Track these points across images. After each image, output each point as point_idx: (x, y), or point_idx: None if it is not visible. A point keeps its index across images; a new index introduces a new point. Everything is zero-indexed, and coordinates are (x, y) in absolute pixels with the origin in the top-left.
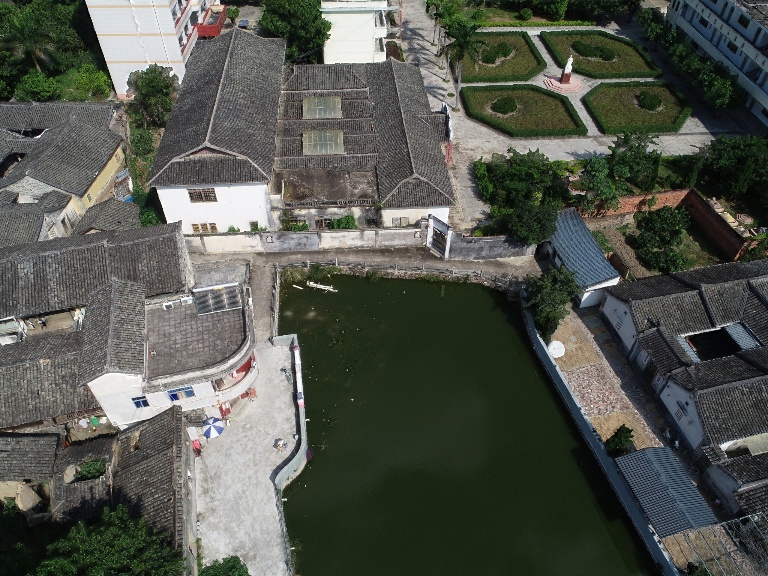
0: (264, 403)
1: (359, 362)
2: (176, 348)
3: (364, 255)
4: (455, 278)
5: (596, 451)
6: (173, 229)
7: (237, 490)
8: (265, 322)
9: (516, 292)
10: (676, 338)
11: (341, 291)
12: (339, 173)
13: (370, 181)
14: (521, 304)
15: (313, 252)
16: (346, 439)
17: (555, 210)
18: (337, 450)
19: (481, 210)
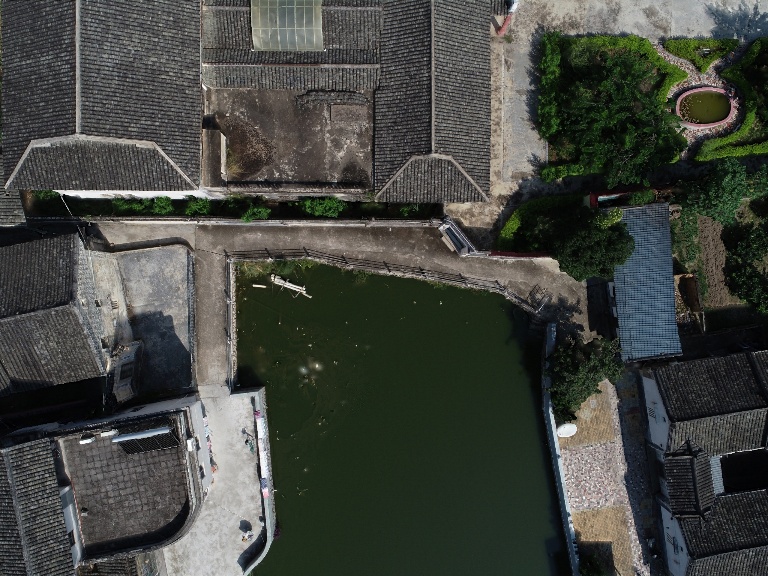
0: (226, 476)
1: (334, 412)
2: (109, 504)
3: (349, 239)
4: (469, 287)
5: (570, 551)
6: (67, 271)
7: (207, 572)
8: (220, 354)
9: (543, 320)
10: (710, 460)
11: (316, 296)
12: (314, 105)
13: (363, 131)
14: (545, 339)
15: (278, 229)
16: (316, 513)
17: (632, 245)
18: (306, 524)
19: (531, 153)
